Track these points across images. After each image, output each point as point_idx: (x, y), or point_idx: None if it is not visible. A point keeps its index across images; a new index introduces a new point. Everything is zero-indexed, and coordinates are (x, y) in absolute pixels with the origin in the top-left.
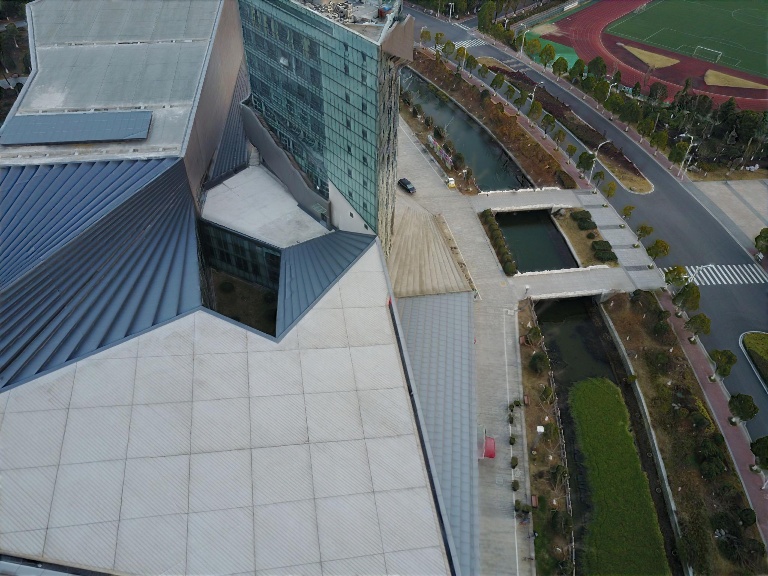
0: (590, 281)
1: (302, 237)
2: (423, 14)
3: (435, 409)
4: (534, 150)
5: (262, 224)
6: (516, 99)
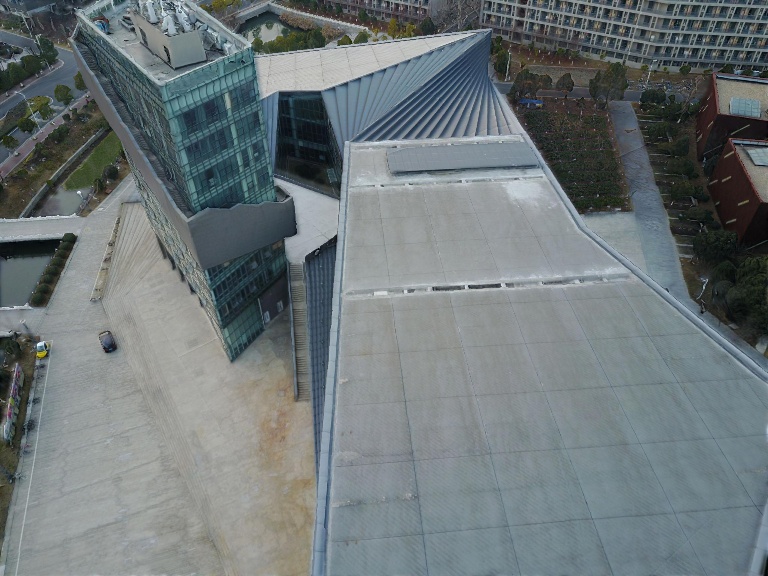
0: (6, 230)
1: None
2: None
3: None
4: None
5: None
6: None
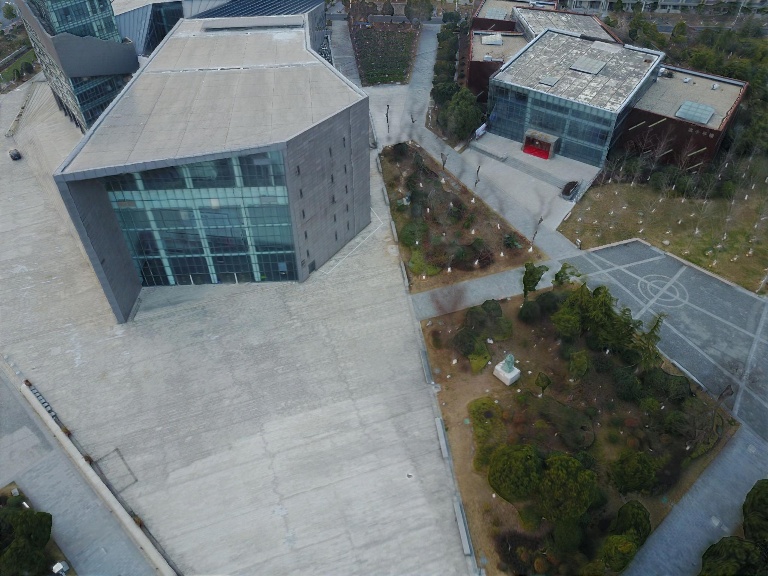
0: None
1: None
2: None
3: None
4: None
5: None
6: None
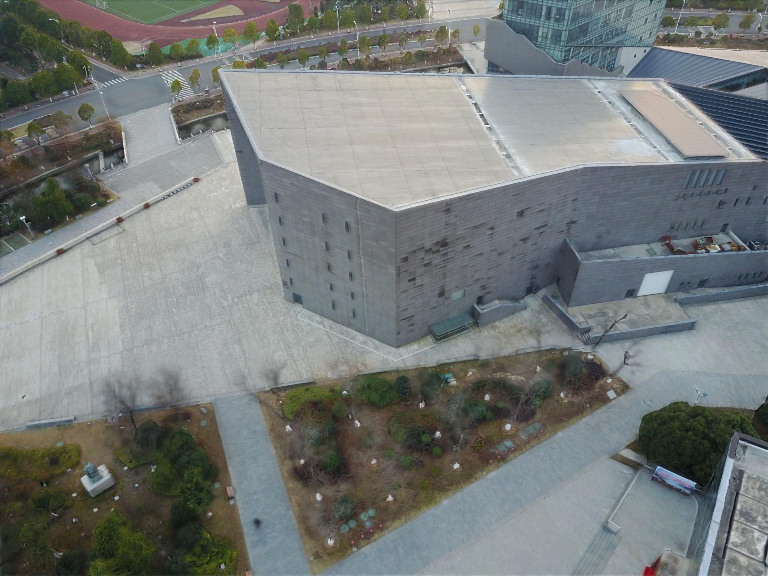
0: None
1: None
2: (59, 103)
3: None
4: (411, 57)
5: None
6: (339, 51)
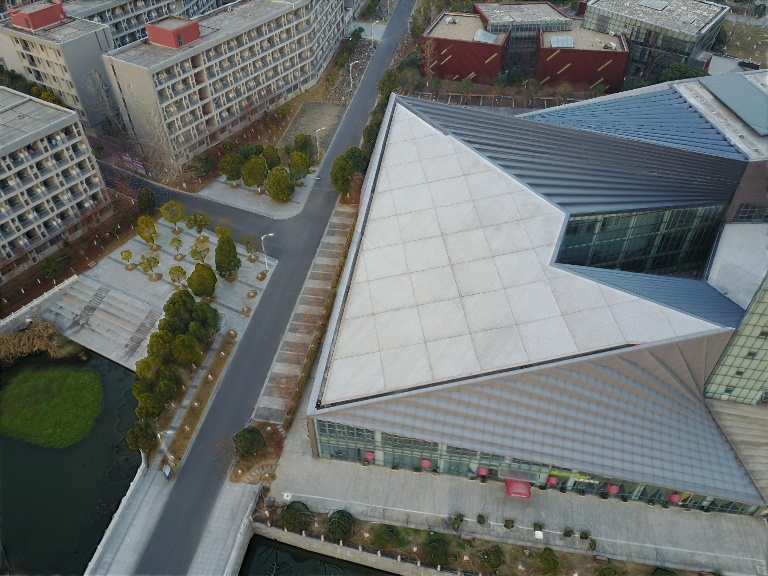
0: None
1: (734, 295)
2: None
3: (527, 408)
4: None
5: (739, 265)
6: None
